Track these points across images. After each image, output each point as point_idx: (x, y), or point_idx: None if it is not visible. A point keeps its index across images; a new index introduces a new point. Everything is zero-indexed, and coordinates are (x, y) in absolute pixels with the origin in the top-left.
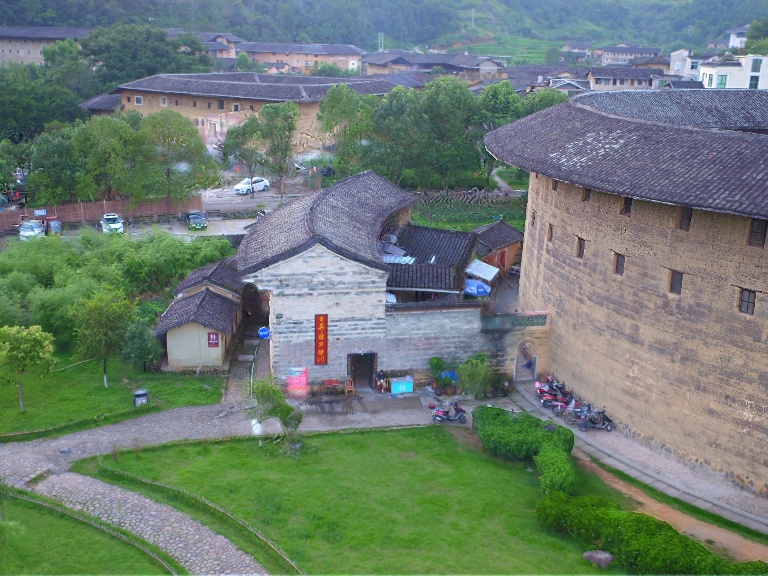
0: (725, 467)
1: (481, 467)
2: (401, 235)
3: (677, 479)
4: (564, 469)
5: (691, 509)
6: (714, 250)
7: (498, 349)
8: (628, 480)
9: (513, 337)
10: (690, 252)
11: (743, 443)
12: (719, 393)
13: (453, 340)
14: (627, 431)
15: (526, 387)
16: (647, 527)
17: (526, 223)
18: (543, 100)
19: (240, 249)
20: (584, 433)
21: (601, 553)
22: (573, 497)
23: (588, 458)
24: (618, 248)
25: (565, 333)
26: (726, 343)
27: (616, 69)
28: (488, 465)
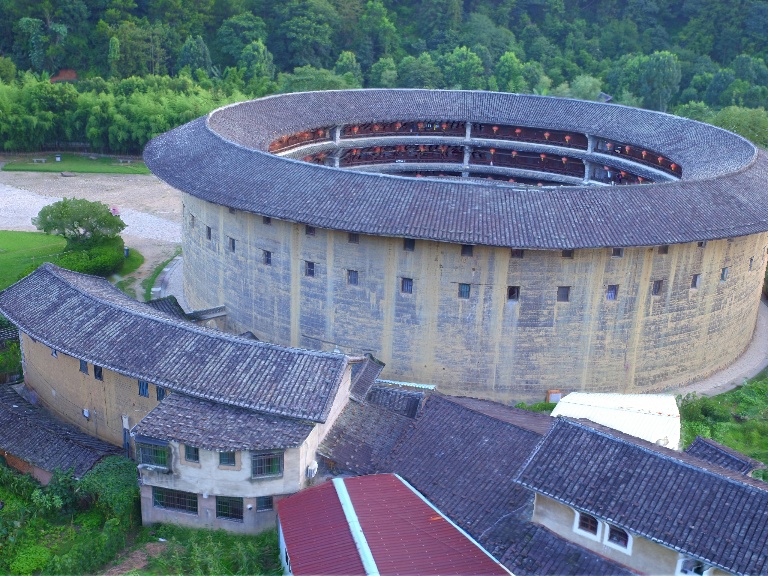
0: None
1: None
2: None
3: None
4: None
5: None
6: None
7: None
8: None
9: None
10: None
11: None
12: None
13: None
14: None
15: None
16: None
17: None
18: None
19: None
20: None
21: None
22: None
23: None
24: None
25: None
26: None
27: None
28: None
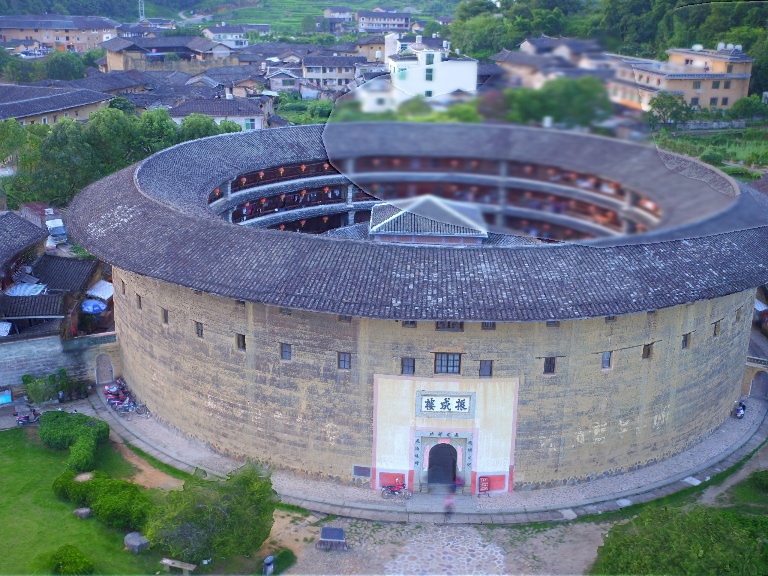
0: (205, 439)
1: (37, 457)
2: (37, 265)
3: (175, 450)
4: (83, 454)
5: (173, 471)
6: (179, 296)
7: (80, 363)
8: (142, 455)
9: (90, 353)
10: (169, 297)
11: (211, 423)
12: (195, 390)
13: (41, 360)
14: (157, 418)
15: (105, 389)
16: (115, 489)
17: None
18: (191, 126)
19: None
20: (128, 422)
21: (84, 509)
22: (81, 473)
23: (122, 441)
24: (137, 291)
25: (124, 348)
26: (194, 358)
27: (325, 58)
28: (43, 455)
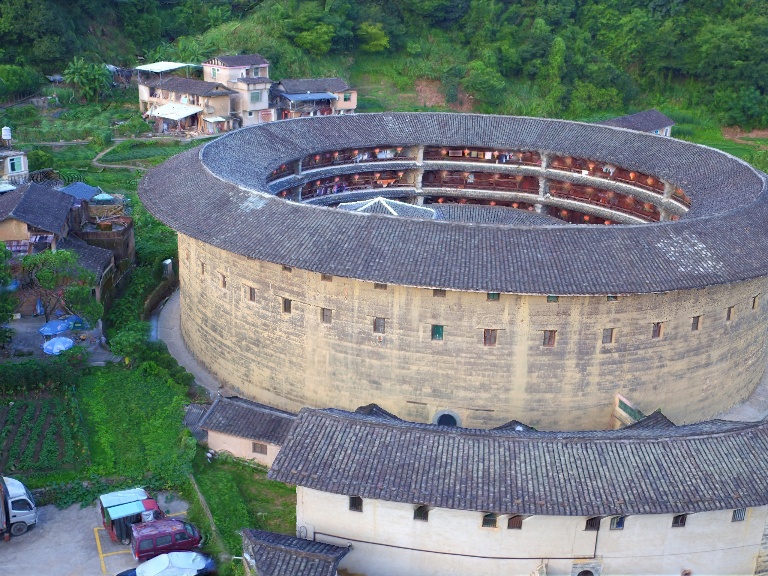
0: None
1: None
2: None
3: (749, 420)
4: None
5: None
6: None
7: None
8: None
9: None
10: None
11: None
12: None
13: None
14: None
15: None
16: None
17: (513, 350)
18: None
19: (724, 506)
20: None
21: None
22: None
23: None
24: None
25: None
26: None
27: None
28: None
